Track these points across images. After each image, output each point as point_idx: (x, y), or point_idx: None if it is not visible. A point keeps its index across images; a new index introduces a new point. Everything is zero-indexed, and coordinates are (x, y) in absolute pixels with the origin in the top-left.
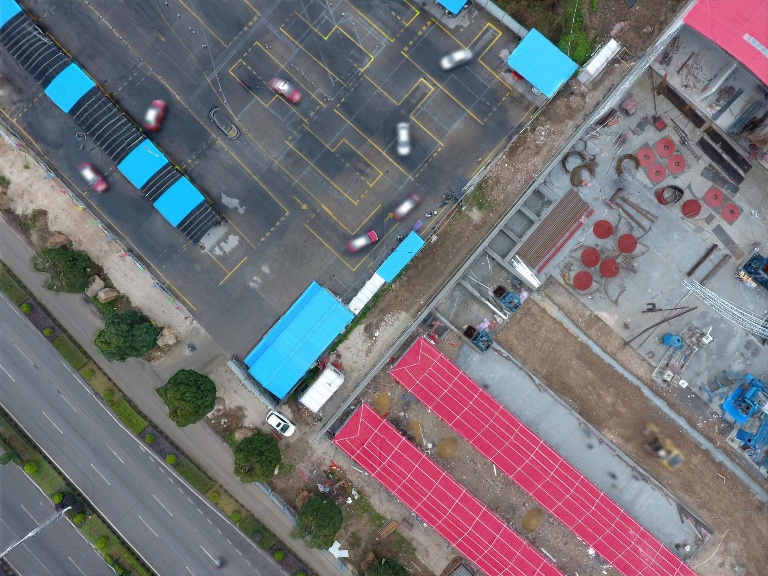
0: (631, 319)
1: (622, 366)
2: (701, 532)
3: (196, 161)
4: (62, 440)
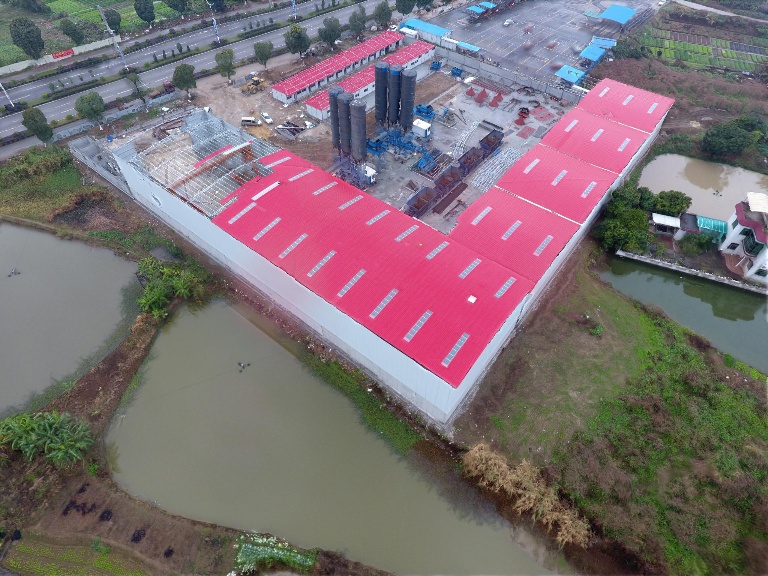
0: (455, 106)
1: None
2: None
3: (492, 19)
4: (382, 0)
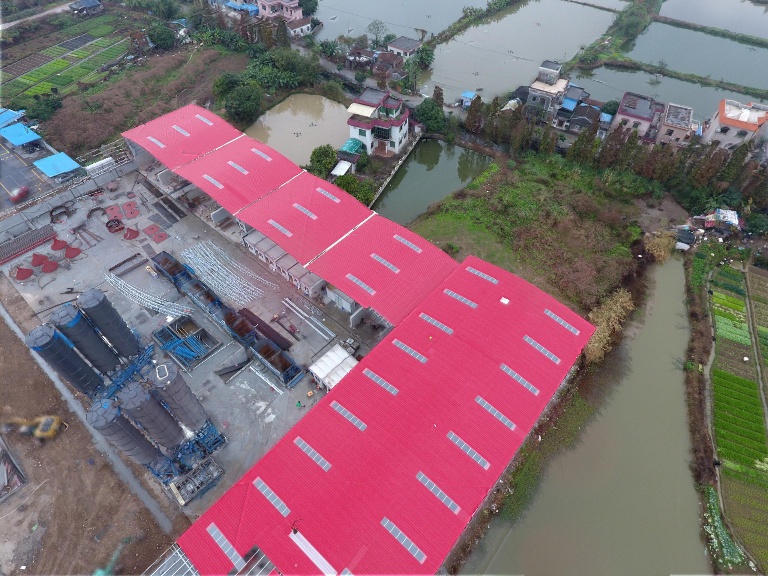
0: (49, 298)
1: (23, 332)
2: (12, 481)
3: None
4: None
